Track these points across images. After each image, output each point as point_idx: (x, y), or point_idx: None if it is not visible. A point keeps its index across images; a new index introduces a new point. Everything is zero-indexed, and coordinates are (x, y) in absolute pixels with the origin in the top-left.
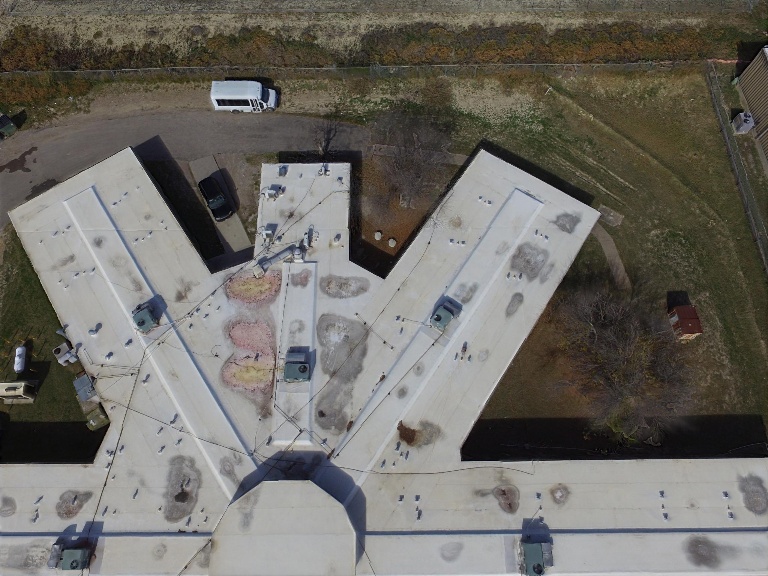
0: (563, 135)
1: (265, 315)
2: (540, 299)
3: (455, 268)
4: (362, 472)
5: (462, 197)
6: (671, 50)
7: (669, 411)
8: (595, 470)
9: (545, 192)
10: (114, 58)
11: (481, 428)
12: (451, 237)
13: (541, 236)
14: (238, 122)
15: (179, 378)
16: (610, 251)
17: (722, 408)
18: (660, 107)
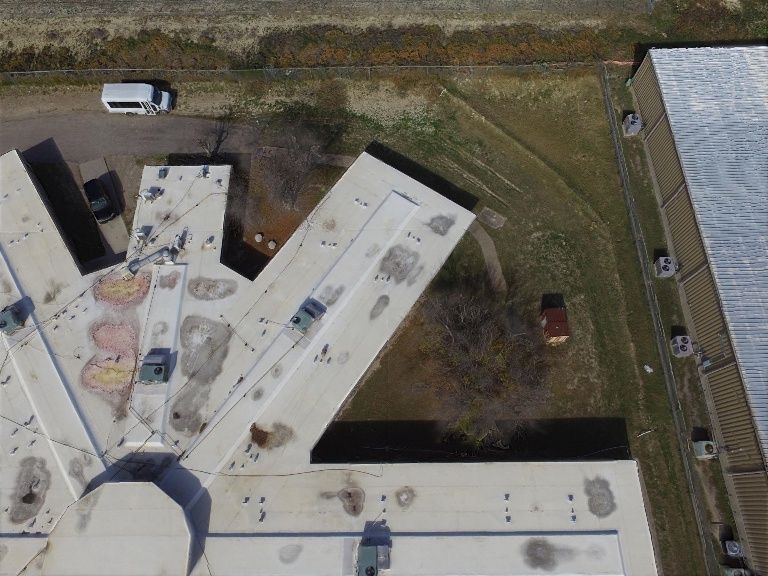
0: (454, 137)
1: (131, 317)
2: (406, 301)
3: (324, 270)
4: (210, 474)
5: (339, 199)
6: (567, 52)
7: (516, 414)
8: (443, 473)
9: (422, 194)
10: (13, 61)
11: (343, 430)
12: (323, 239)
13: (413, 238)
14: (132, 124)
15: (38, 380)
16: (489, 253)
17: (586, 411)
18: (553, 109)
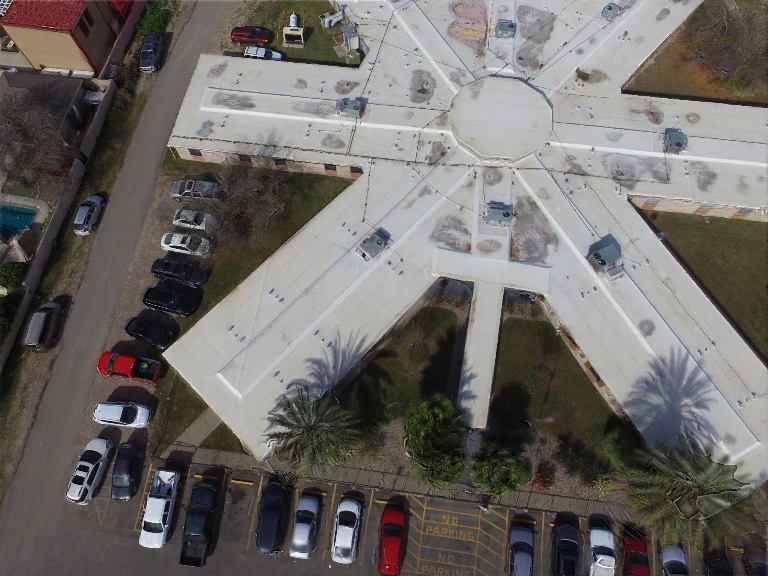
0: None
1: (479, 2)
2: (682, 13)
3: None
4: (551, 90)
5: None
6: None
7: None
8: (719, 108)
9: None
10: None
11: None
12: None
13: None
14: None
15: (419, 28)
16: (732, 7)
17: None
18: None
